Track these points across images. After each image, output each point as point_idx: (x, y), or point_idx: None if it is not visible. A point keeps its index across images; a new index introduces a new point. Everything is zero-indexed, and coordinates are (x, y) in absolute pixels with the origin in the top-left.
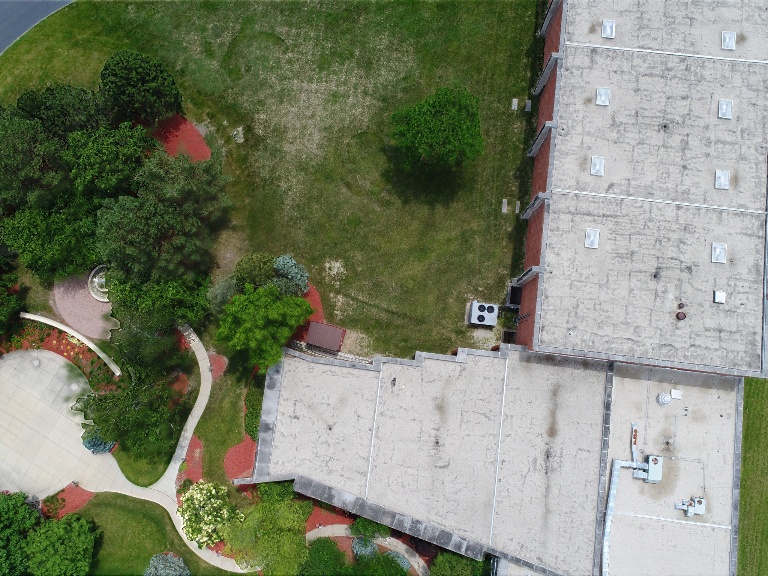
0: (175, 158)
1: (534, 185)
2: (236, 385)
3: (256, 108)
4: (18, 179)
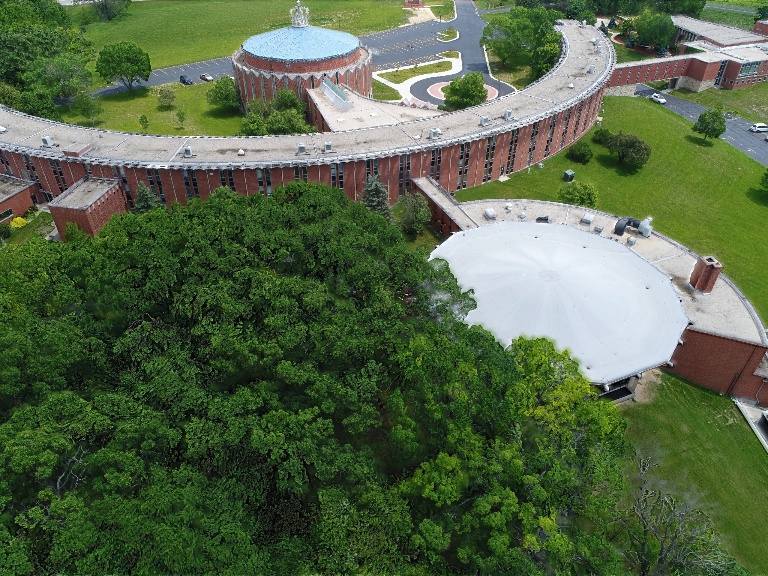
0: None
1: None
2: None
3: None
4: None
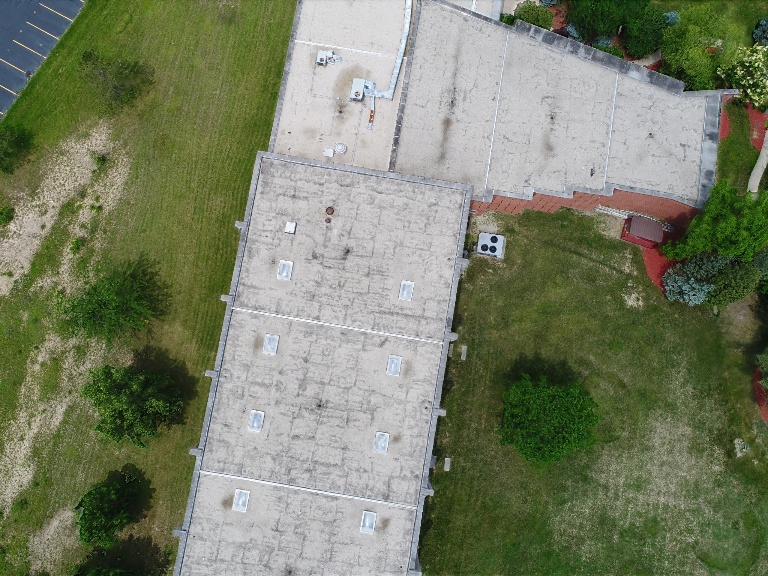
0: None
1: None
2: None
3: (724, 478)
4: None
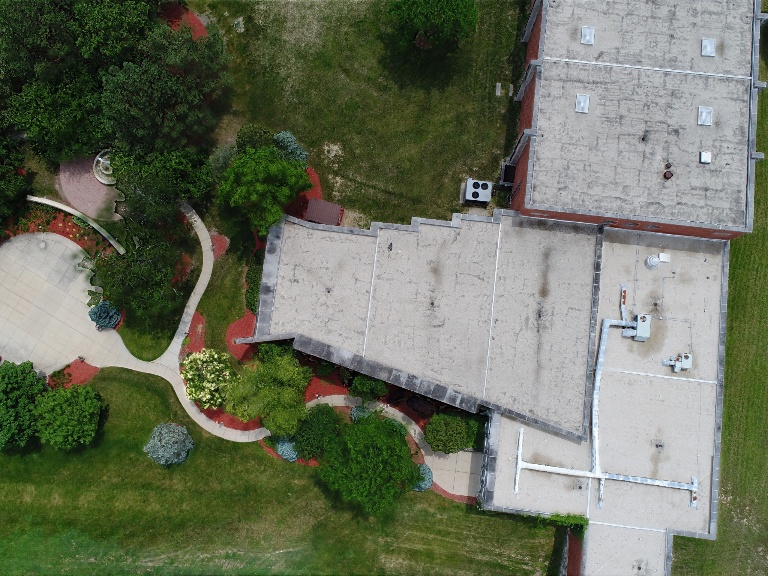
0: (178, 31)
1: (527, 66)
2: (237, 263)
3: None
4: (25, 49)
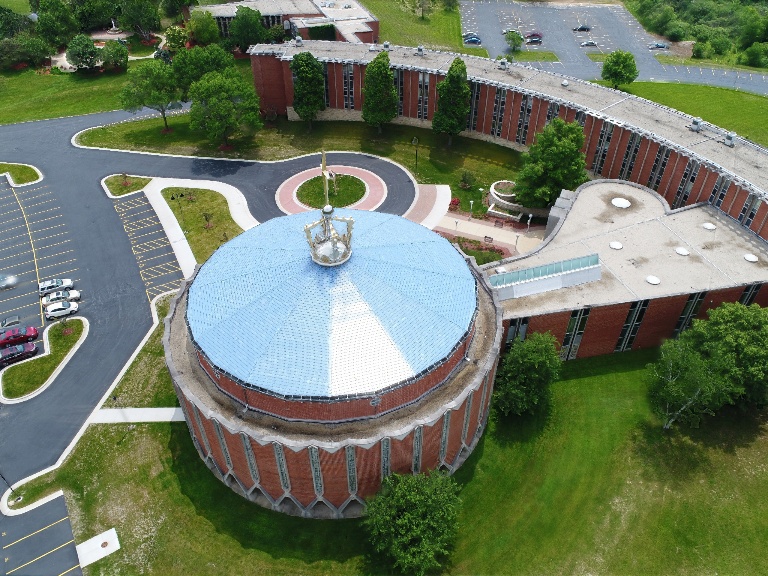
0: None
1: None
2: None
3: None
4: None
